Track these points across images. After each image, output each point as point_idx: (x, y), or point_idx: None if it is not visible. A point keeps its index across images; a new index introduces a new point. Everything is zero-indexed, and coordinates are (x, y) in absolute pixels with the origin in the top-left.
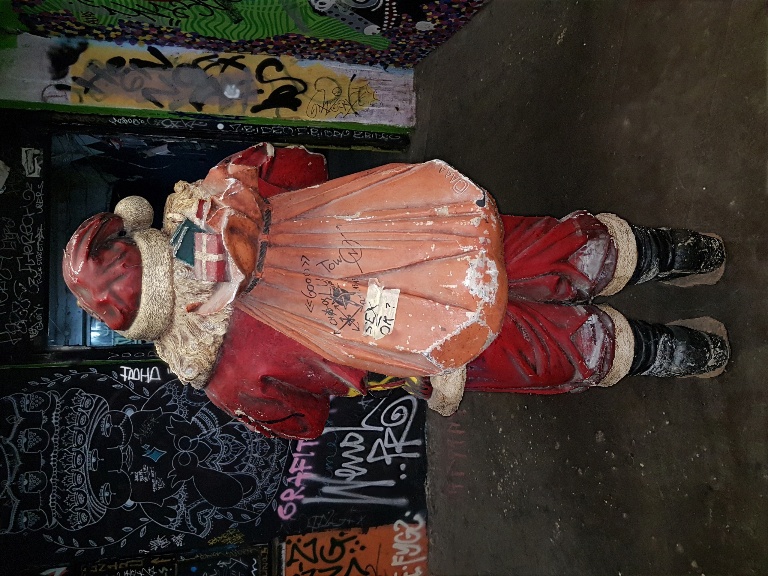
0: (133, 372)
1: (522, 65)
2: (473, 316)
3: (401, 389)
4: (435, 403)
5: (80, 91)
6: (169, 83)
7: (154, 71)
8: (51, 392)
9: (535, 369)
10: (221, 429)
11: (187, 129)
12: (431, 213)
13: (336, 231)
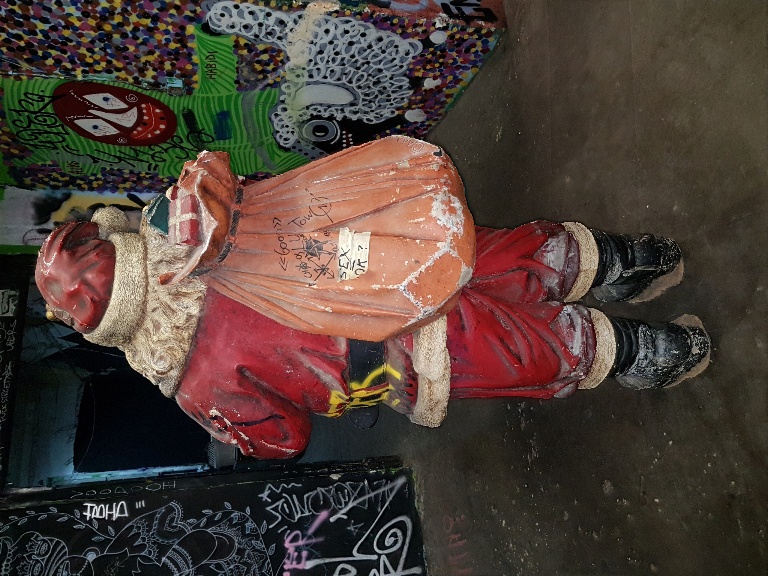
0: (98, 509)
1: (469, 168)
2: (444, 246)
3: (393, 509)
4: (422, 405)
5: None
6: None
7: (132, 214)
8: (3, 538)
9: (520, 359)
10: (195, 570)
11: None
12: (393, 166)
13: (305, 193)
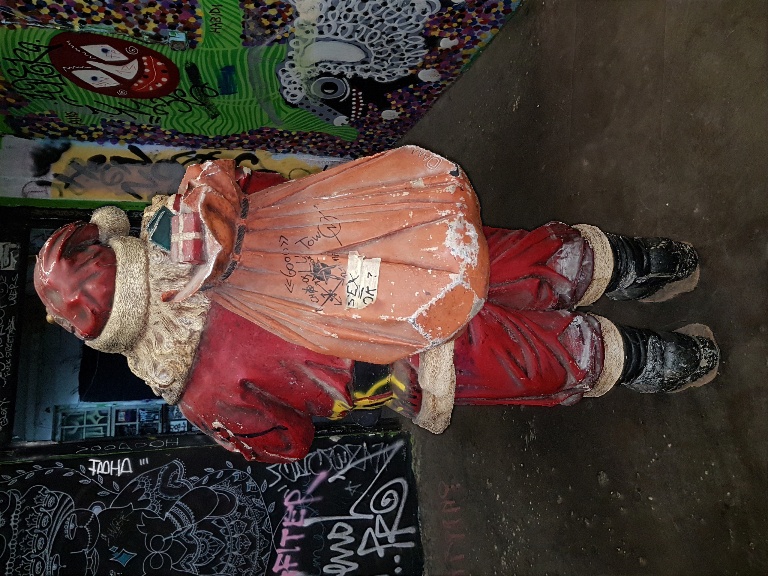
0: (102, 465)
1: (483, 136)
2: (457, 278)
3: (390, 472)
4: (426, 415)
5: (60, 186)
6: (148, 177)
7: (134, 167)
8: (11, 491)
9: (526, 372)
10: (197, 525)
11: None
12: (407, 185)
13: (314, 210)
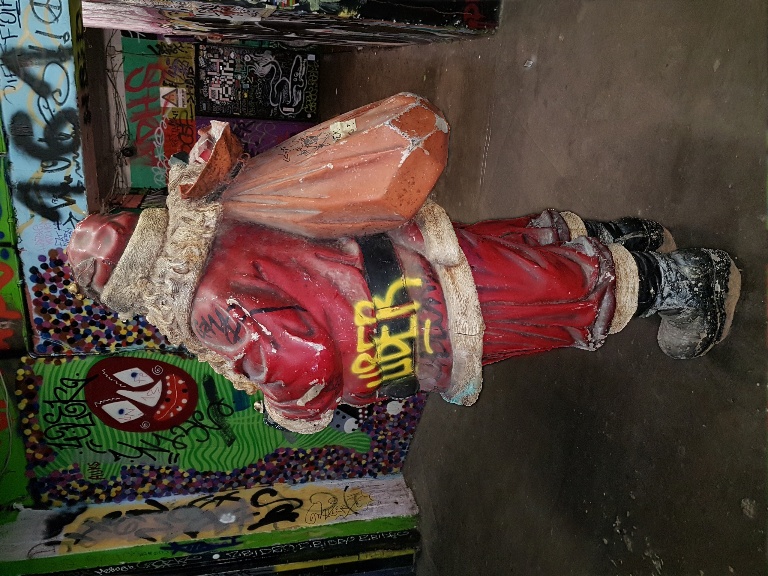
0: None
1: None
2: (415, 103)
3: None
4: (453, 309)
5: (70, 543)
6: (164, 522)
7: (149, 516)
8: None
9: None
10: None
11: (180, 566)
12: None
13: None
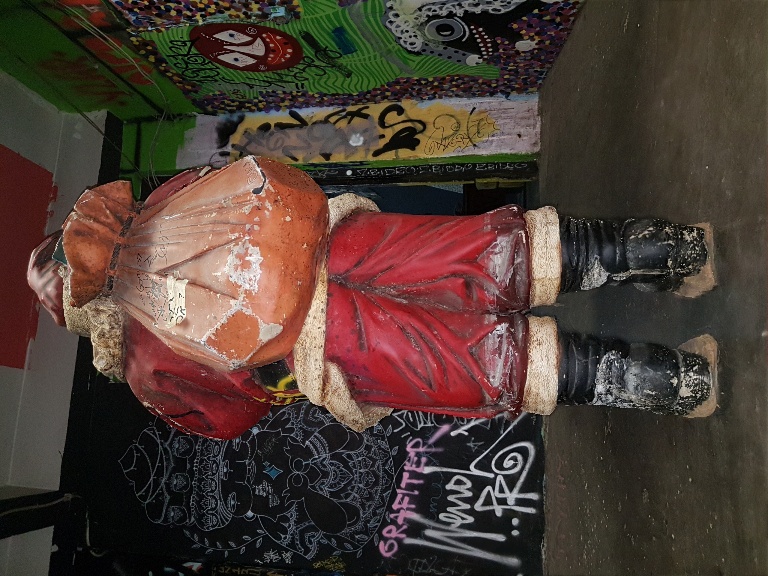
0: None
1: (603, 64)
2: (235, 304)
3: (516, 434)
4: None
5: (236, 155)
6: (304, 139)
7: (293, 131)
8: None
9: (429, 383)
10: (331, 455)
11: (321, 178)
12: (219, 205)
13: (160, 229)
